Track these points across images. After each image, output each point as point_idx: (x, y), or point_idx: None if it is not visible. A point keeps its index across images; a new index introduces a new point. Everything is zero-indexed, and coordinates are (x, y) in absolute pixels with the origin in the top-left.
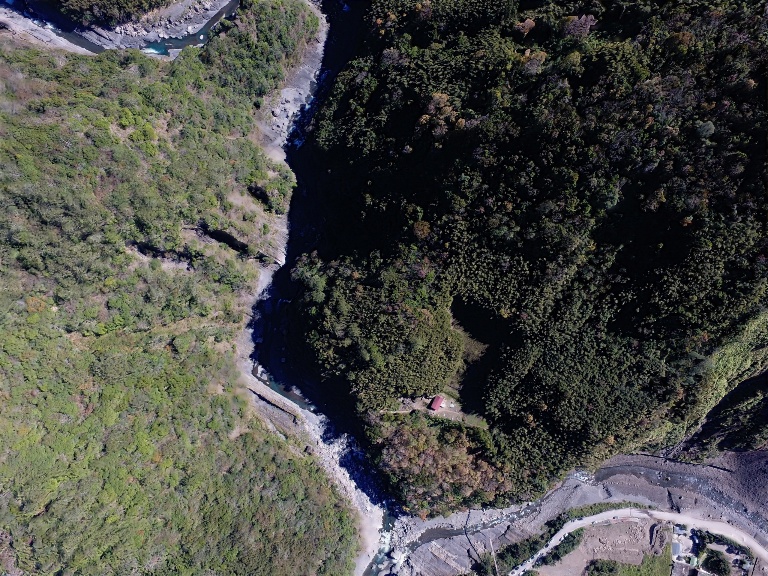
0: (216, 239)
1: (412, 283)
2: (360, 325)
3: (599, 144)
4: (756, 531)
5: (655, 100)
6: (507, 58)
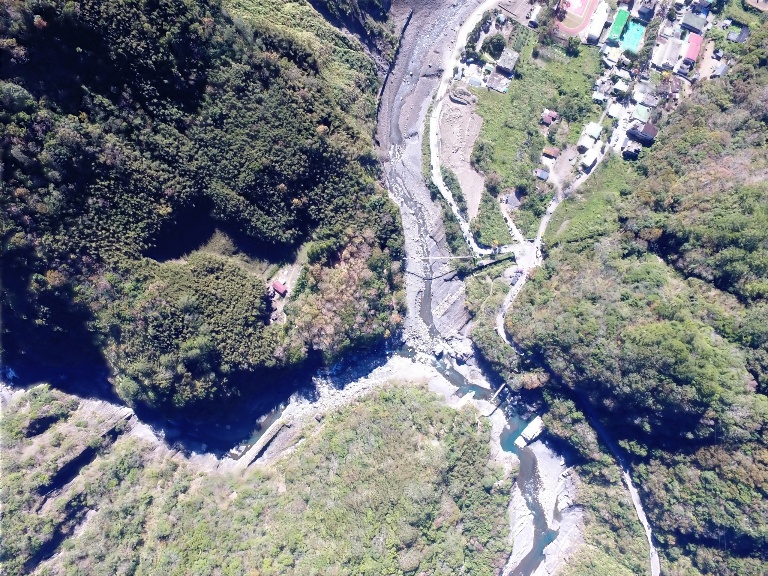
0: (75, 477)
1: (117, 296)
2: (163, 353)
3: None
4: (474, 0)
5: None
6: None
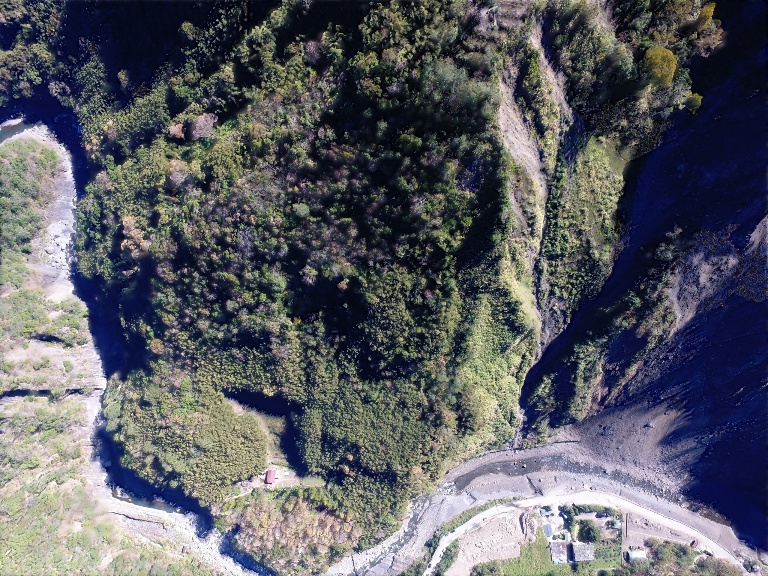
0: (18, 395)
1: (174, 394)
2: (153, 442)
3: (231, 246)
4: (620, 488)
5: (247, 200)
6: (159, 174)
